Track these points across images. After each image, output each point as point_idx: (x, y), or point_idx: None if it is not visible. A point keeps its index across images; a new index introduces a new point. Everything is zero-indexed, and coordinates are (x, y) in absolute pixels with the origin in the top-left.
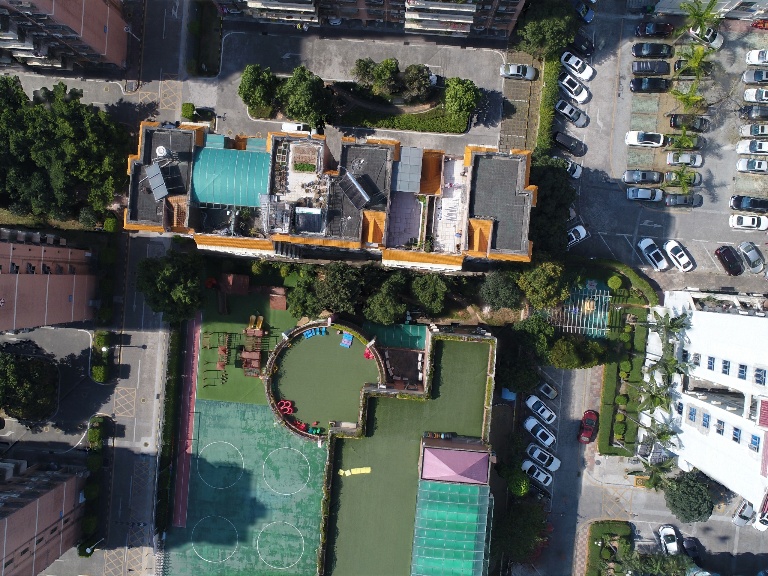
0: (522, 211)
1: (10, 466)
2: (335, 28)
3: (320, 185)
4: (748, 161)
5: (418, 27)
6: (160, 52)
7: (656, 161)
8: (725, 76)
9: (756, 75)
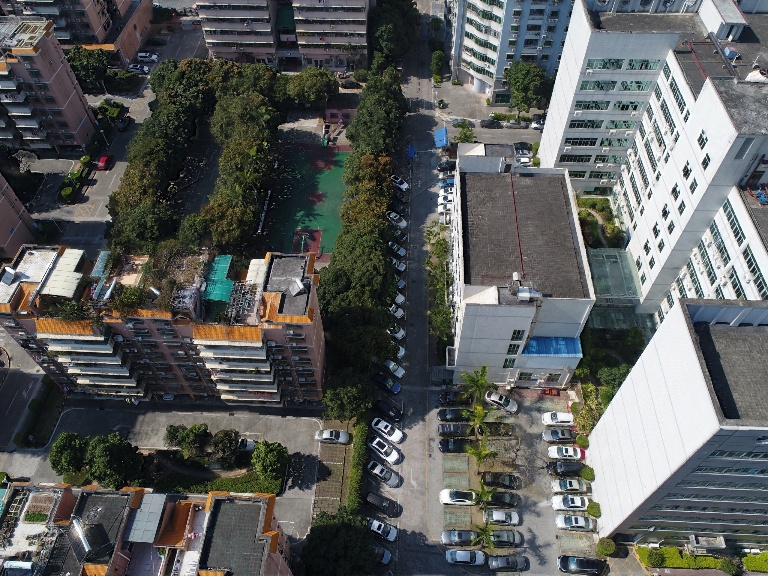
0: (260, 560)
1: None
2: (168, 403)
3: (47, 537)
4: (565, 517)
5: (233, 398)
6: None
7: (474, 520)
8: (527, 436)
9: (553, 434)
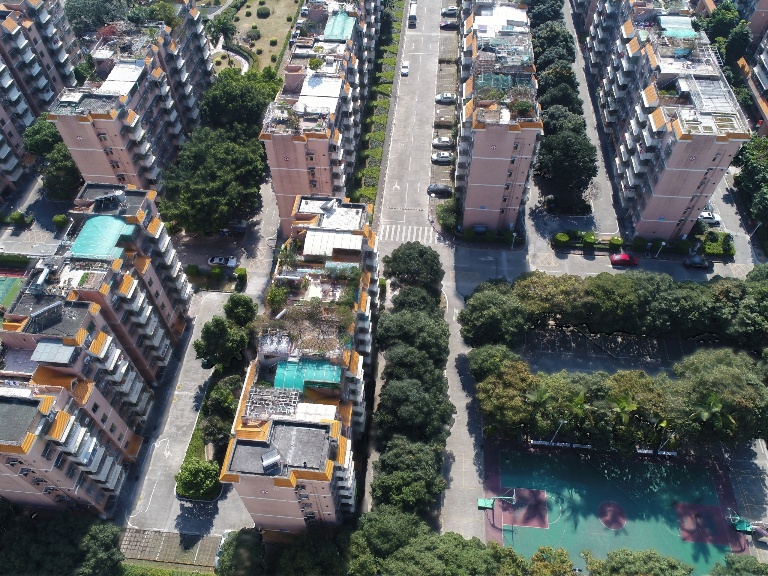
0: None
1: (10, 168)
2: None
3: None
4: None
5: None
6: None
7: None
8: None
9: None
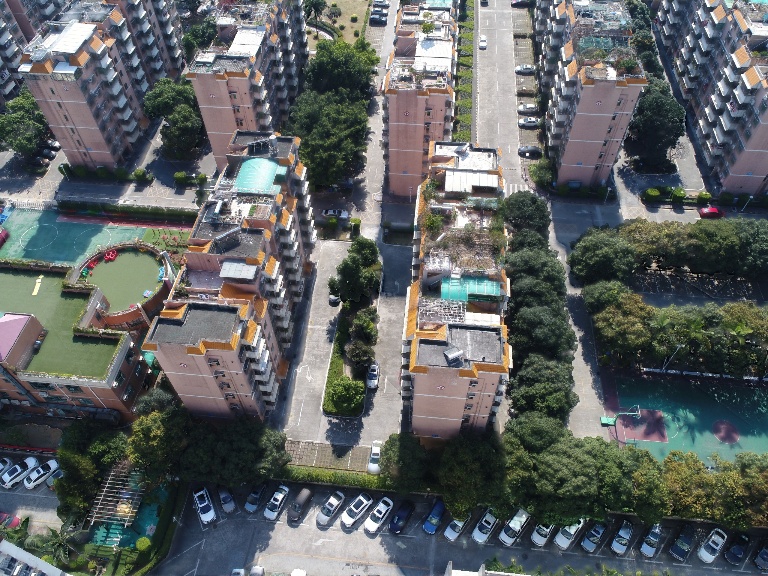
0: (185, 343)
1: (131, 130)
2: None
3: None
4: None
5: None
6: (402, 213)
7: None
8: None
9: None
